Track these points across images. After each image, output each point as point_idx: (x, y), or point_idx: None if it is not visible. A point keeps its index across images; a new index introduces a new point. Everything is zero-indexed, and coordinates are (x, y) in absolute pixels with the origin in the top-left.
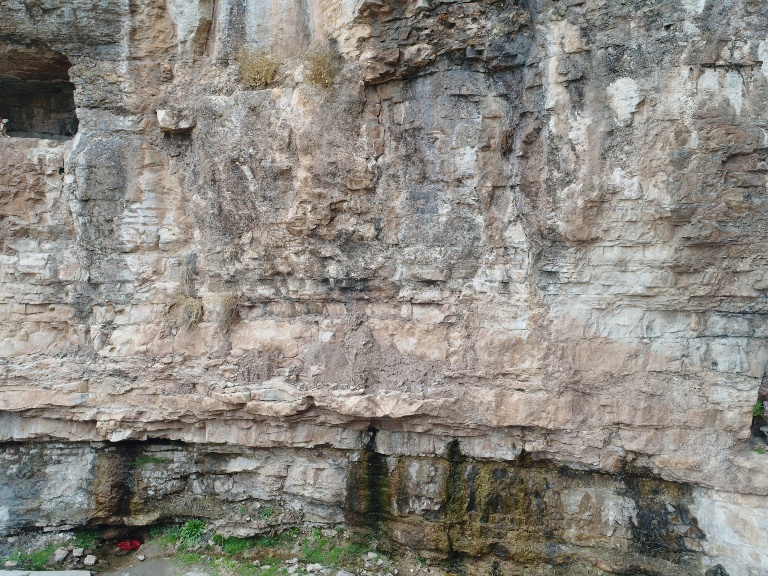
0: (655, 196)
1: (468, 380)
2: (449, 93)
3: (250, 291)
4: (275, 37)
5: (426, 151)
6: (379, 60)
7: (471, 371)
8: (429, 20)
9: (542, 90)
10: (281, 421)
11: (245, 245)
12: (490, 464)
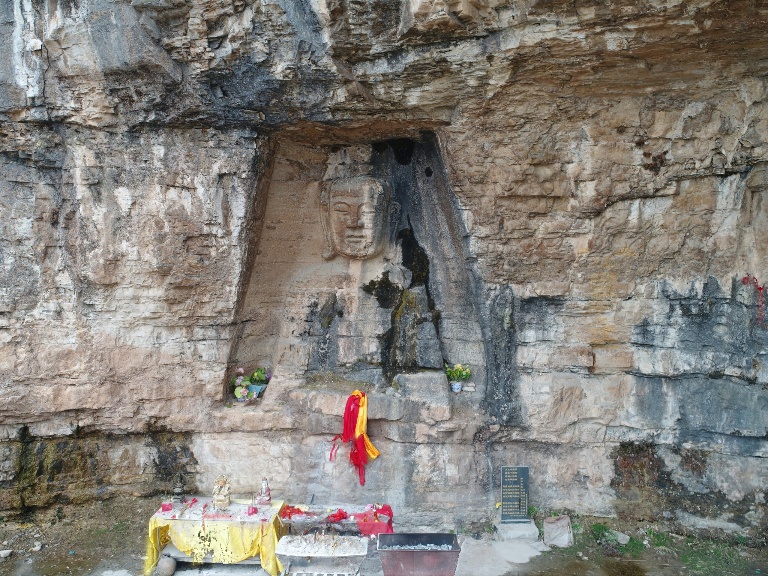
0: (148, 259)
1: (32, 382)
2: (8, 179)
3: None
4: None
5: None
6: None
7: (34, 375)
8: None
9: (74, 187)
10: None
11: None
12: (55, 440)
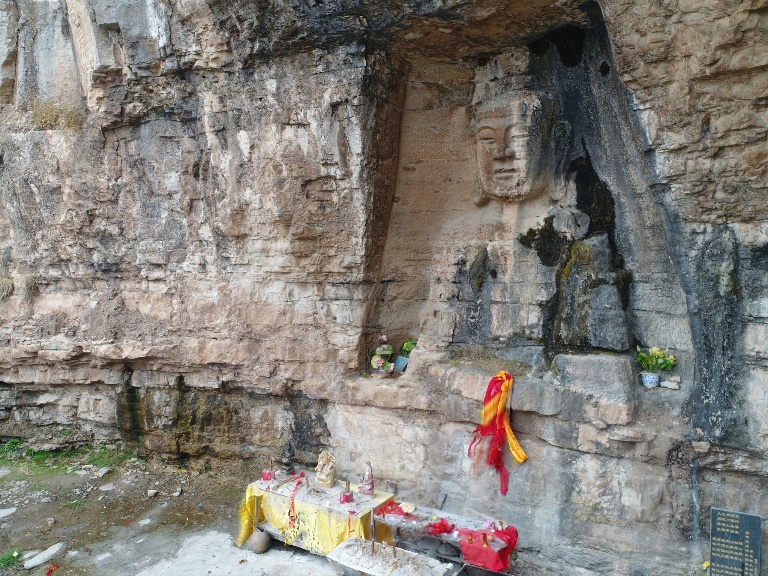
0: (269, 207)
1: (183, 333)
2: (159, 135)
3: (45, 273)
4: (61, 90)
5: (149, 174)
6: (109, 113)
7: (185, 326)
8: (137, 87)
9: (206, 136)
10: (64, 364)
11: (39, 240)
12: (206, 392)
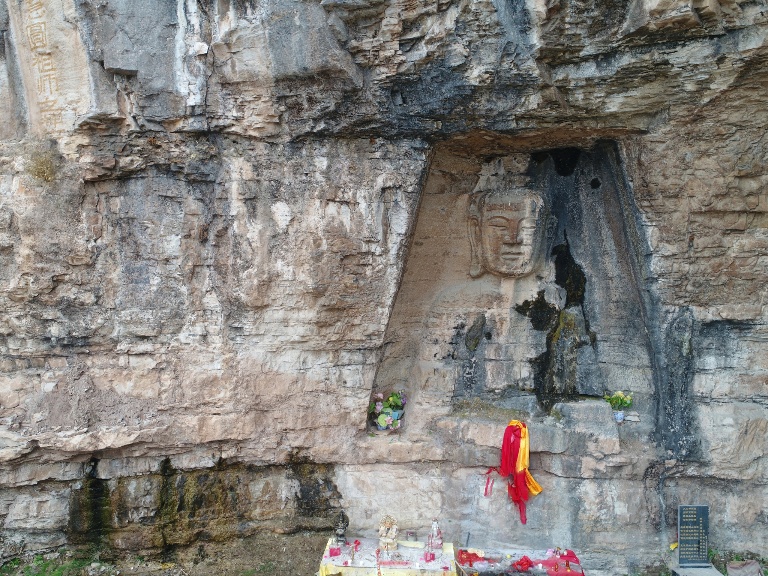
0: (303, 279)
1: (177, 411)
2: (157, 194)
3: None
4: None
5: (139, 236)
6: (97, 165)
7: (179, 404)
8: (140, 140)
9: (228, 202)
10: (3, 465)
11: None
12: (195, 472)
